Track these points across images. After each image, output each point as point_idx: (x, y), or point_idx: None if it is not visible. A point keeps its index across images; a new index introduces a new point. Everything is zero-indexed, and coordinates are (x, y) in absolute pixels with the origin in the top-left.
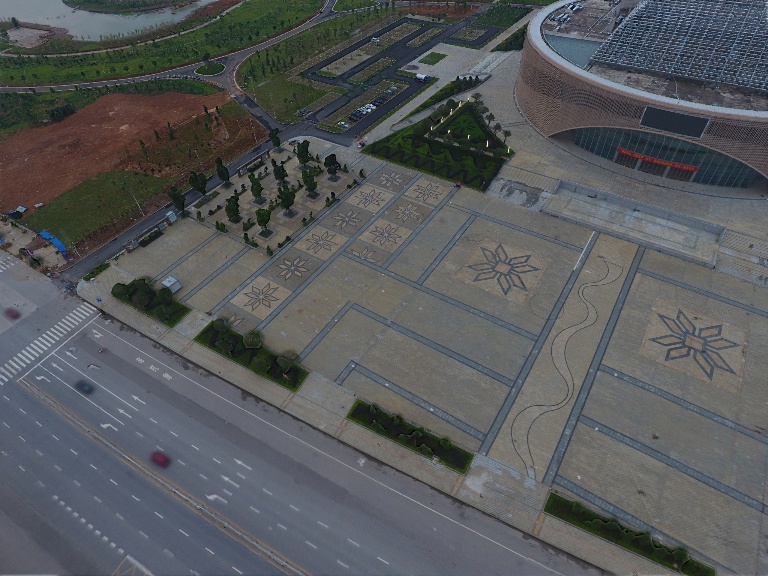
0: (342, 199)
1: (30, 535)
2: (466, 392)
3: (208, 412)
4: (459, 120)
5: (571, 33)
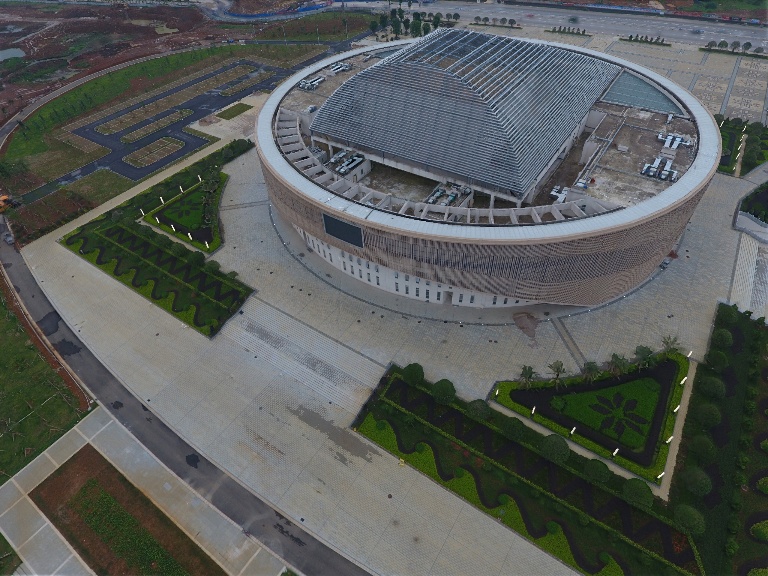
0: (767, 102)
1: (753, 29)
2: (627, 48)
3: (729, 44)
4: (723, 140)
5: (648, 115)
